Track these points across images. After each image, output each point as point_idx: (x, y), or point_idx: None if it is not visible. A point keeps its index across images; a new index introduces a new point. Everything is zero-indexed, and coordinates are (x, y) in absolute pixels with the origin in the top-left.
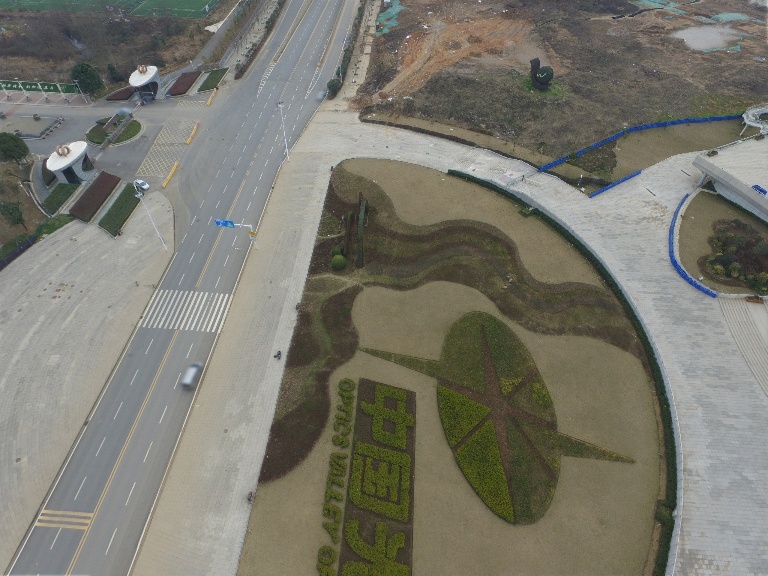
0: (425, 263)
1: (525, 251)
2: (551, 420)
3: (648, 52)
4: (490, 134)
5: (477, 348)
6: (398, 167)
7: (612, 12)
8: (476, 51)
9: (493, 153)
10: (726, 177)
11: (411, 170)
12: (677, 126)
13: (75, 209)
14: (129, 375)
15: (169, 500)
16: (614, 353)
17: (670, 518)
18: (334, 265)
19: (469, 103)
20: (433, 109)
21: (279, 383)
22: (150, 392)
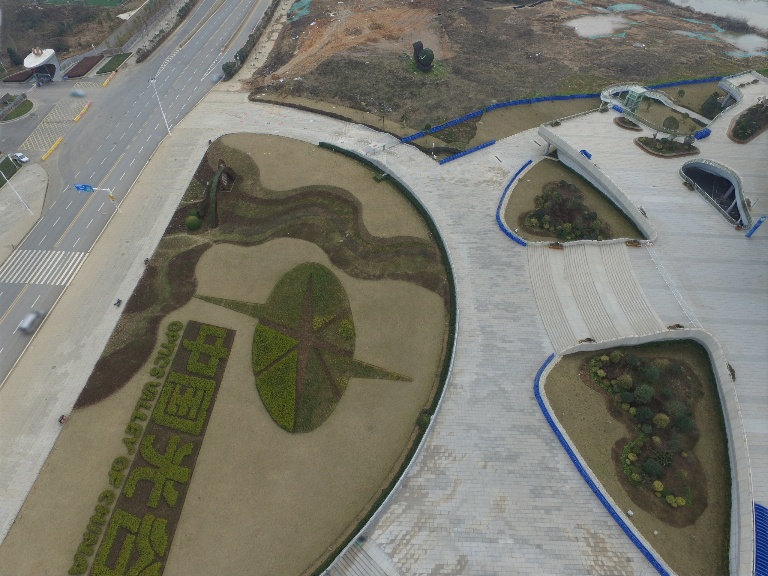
0: (275, 223)
1: (369, 211)
2: (349, 349)
3: (537, 38)
4: (368, 111)
5: (301, 292)
6: (274, 141)
7: (514, 2)
8: (374, 37)
9: (365, 127)
10: (561, 144)
11: (285, 143)
12: (541, 103)
13: None
14: None
15: None
16: (422, 293)
17: (428, 423)
18: (187, 225)
19: (355, 83)
20: (320, 89)
21: (113, 326)
22: None
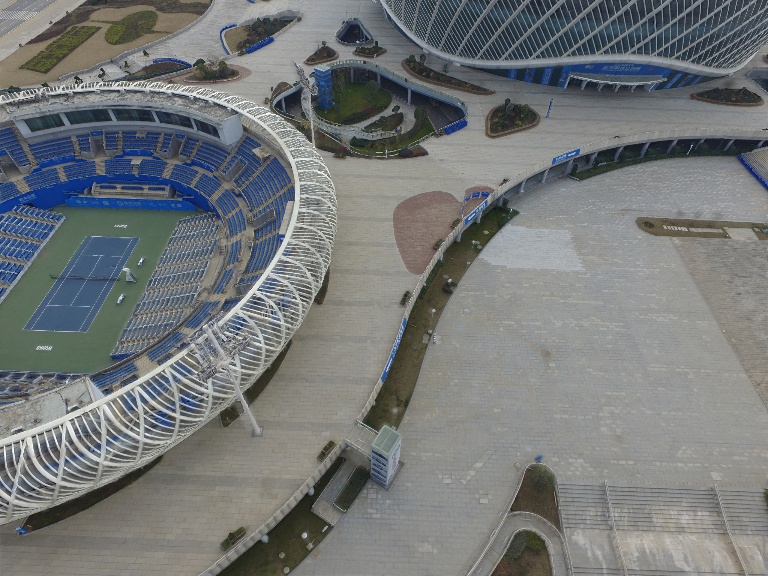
0: None
1: None
2: None
3: None
4: None
5: (137, 17)
6: None
7: None
8: None
9: None
10: None
11: None
12: None
13: None
14: None
15: None
16: (193, 15)
17: None
18: (90, 1)
19: None
20: None
21: (47, 28)
22: None
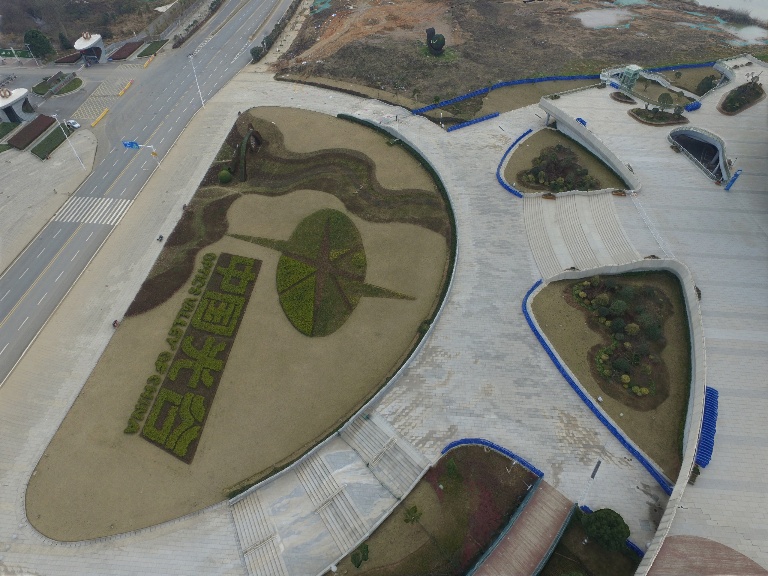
0: (297, 178)
1: (381, 169)
2: (361, 275)
3: (544, 28)
4: (383, 89)
5: (319, 232)
6: (297, 113)
7: None
8: (390, 26)
9: (380, 102)
10: (559, 114)
11: (307, 115)
12: (544, 82)
13: (13, 140)
14: (37, 251)
15: (52, 327)
16: (426, 234)
17: None
18: (220, 178)
19: (371, 66)
20: (339, 70)
21: (156, 256)
22: (52, 262)
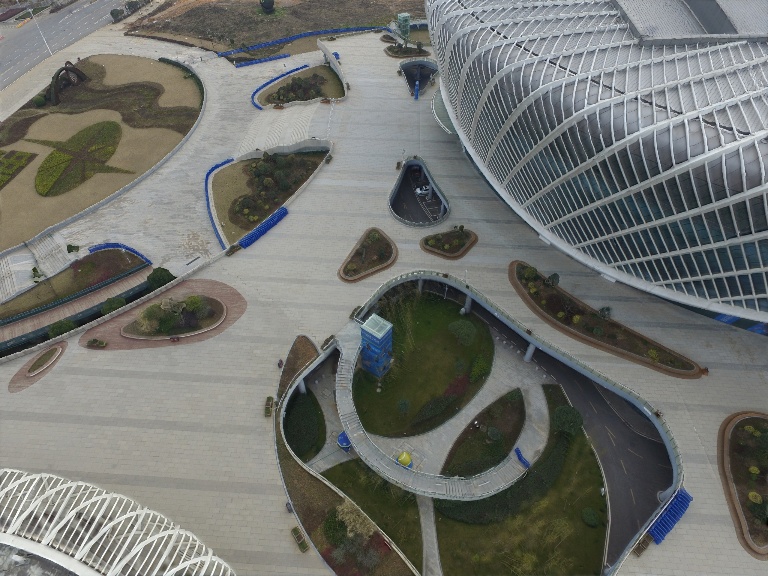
0: (98, 102)
1: (167, 94)
2: (105, 160)
3: None
4: None
5: (92, 135)
6: (128, 58)
7: None
8: None
9: (200, 49)
10: (326, 51)
11: (135, 60)
12: (347, 32)
13: None
14: None
15: None
16: (172, 134)
17: None
18: (34, 102)
19: (209, 23)
20: (182, 27)
21: None
22: None
